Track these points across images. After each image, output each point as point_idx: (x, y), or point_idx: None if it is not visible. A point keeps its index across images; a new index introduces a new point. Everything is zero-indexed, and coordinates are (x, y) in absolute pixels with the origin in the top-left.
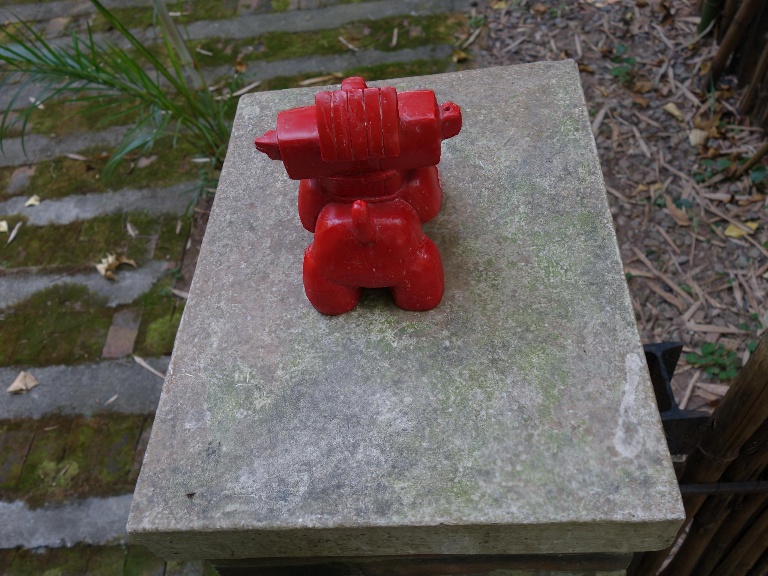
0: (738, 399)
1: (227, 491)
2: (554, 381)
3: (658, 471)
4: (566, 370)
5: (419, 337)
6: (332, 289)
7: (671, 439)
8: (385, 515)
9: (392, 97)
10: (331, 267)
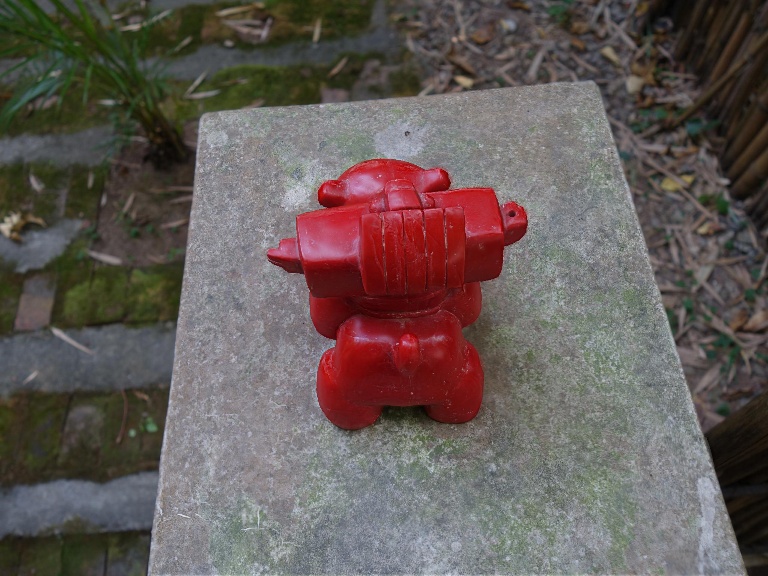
0: (740, 435)
1: None
2: (622, 516)
3: None
4: (633, 501)
5: (459, 459)
6: (357, 410)
7: None
8: None
9: (460, 220)
10: (359, 391)
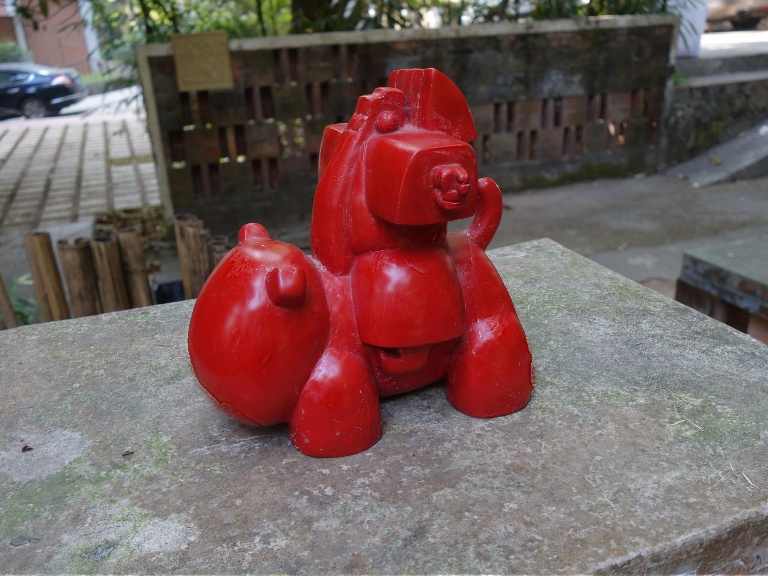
0: None
1: None
2: None
3: (525, 245)
4: None
5: None
6: None
7: None
8: (686, 308)
9: None
10: None
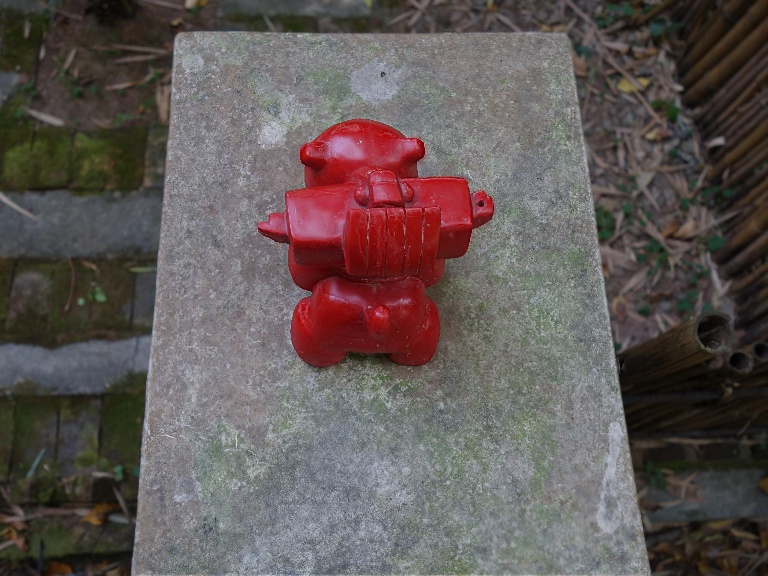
0: (652, 360)
1: (231, 573)
2: (544, 452)
3: (633, 547)
4: (555, 440)
5: (413, 397)
6: (328, 355)
7: (645, 514)
8: None
9: (437, 220)
10: (332, 341)
